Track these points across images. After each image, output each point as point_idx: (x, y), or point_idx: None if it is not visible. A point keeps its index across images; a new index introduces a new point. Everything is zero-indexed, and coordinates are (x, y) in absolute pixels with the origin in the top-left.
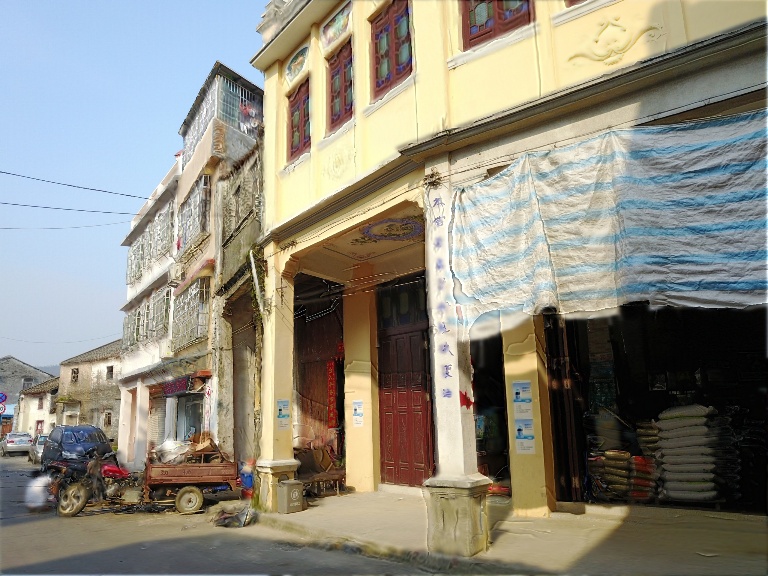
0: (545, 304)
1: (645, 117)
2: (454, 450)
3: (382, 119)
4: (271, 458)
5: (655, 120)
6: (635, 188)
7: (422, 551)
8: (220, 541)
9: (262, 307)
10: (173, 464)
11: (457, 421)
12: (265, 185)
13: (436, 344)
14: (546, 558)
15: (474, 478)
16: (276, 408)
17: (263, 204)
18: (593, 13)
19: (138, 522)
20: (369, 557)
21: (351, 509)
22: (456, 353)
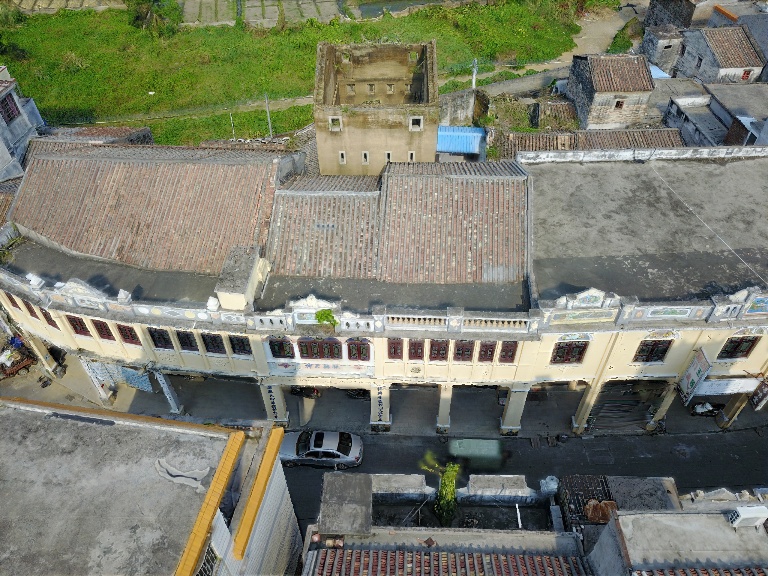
0: (113, 385)
1: (123, 365)
2: (103, 393)
3: (56, 333)
4: (50, 369)
5: (125, 366)
6: (124, 374)
7: (102, 403)
8: (50, 399)
9: (27, 341)
10: (12, 367)
11: (102, 390)
12: (5, 307)
13: (93, 379)
14: (127, 403)
15: (109, 395)
16: (45, 358)
17: (7, 310)
18: (108, 343)
19: (14, 387)
20: (91, 403)
21: (79, 368)
22: (98, 381)
